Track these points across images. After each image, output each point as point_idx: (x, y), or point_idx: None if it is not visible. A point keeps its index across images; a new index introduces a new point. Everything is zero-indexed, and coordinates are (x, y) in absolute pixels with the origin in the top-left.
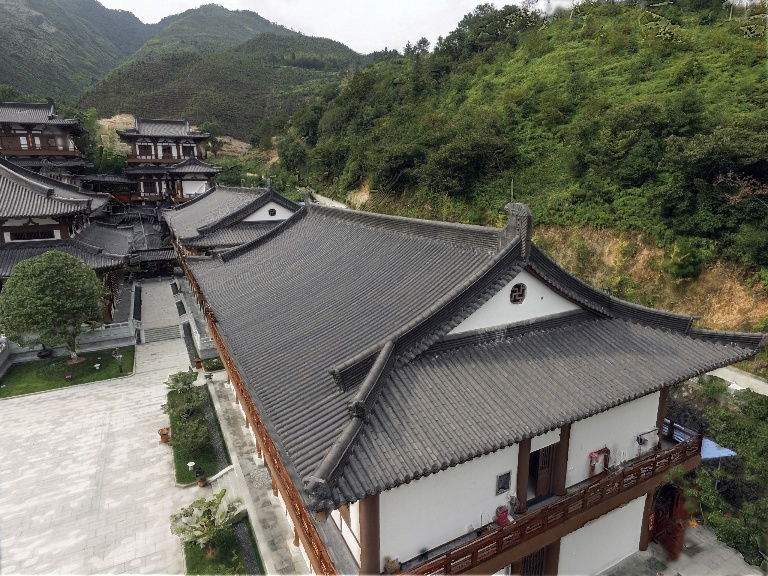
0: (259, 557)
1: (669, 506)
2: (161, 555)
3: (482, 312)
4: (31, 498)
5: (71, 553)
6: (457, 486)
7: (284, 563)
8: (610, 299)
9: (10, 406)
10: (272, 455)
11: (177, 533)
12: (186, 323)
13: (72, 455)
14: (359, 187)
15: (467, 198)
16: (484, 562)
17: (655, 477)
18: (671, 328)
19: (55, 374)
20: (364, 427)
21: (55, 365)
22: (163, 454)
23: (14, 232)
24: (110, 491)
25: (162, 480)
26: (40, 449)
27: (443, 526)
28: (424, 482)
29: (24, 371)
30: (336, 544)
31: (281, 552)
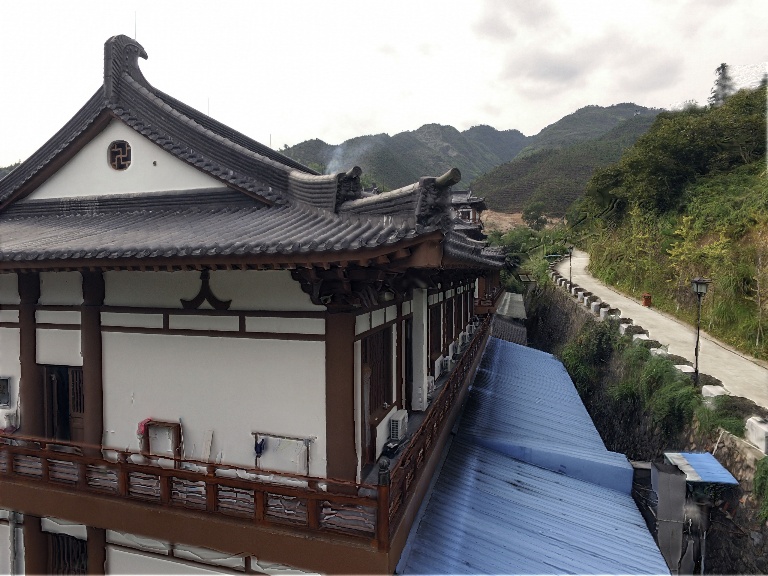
0: None
1: None
2: None
3: (72, 176)
4: None
5: None
6: None
7: None
8: (289, 174)
9: None
10: None
11: None
12: None
13: None
14: (590, 227)
15: (679, 211)
16: None
17: (211, 520)
18: (325, 206)
19: None
20: None
21: None
22: None
23: None
24: None
25: None
26: None
27: None
28: None
29: None
30: None
31: None
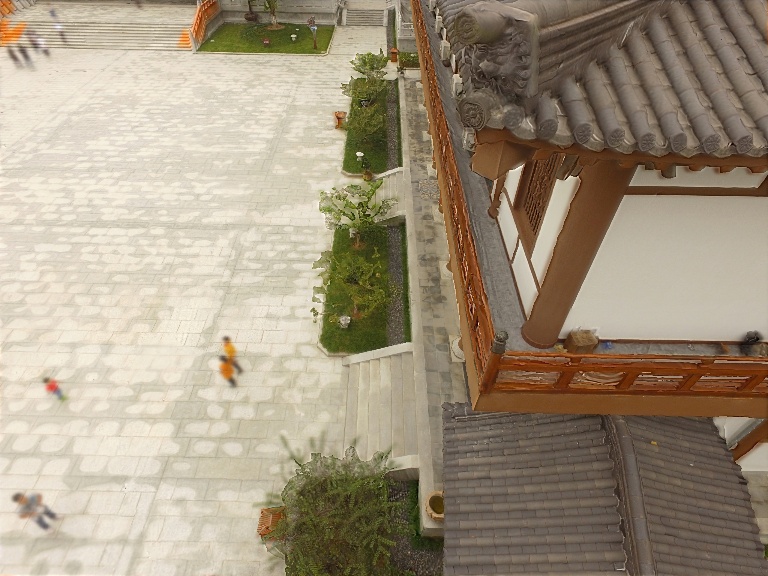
0: (406, 267)
1: None
2: (312, 231)
3: None
4: (216, 145)
5: (238, 201)
6: None
7: (430, 282)
8: None
9: (215, 60)
10: (441, 140)
11: (324, 211)
12: (392, 9)
13: (256, 117)
14: None
15: None
16: (762, 397)
17: None
18: None
19: (256, 37)
20: (672, 1)
21: (257, 28)
22: (337, 139)
23: None
24: (281, 159)
25: (330, 163)
26: (231, 104)
27: (704, 314)
28: (721, 221)
29: (231, 30)
30: (499, 275)
31: (430, 270)
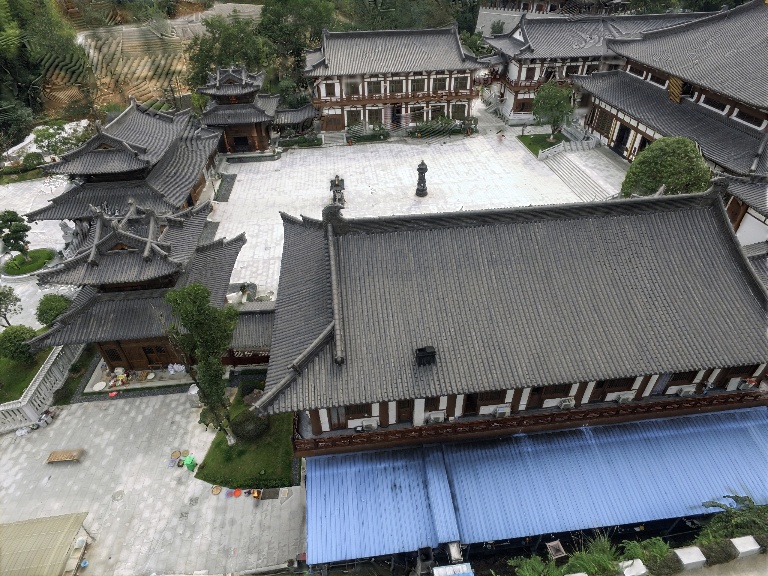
0: None
1: None
2: None
3: None
4: None
5: None
6: None
7: None
8: None
9: None
10: None
11: None
12: None
13: None
14: None
15: None
16: None
17: None
18: None
19: None
20: None
21: None
22: None
23: (741, 110)
24: None
25: None
26: None
27: None
28: None
29: None
30: None
31: None
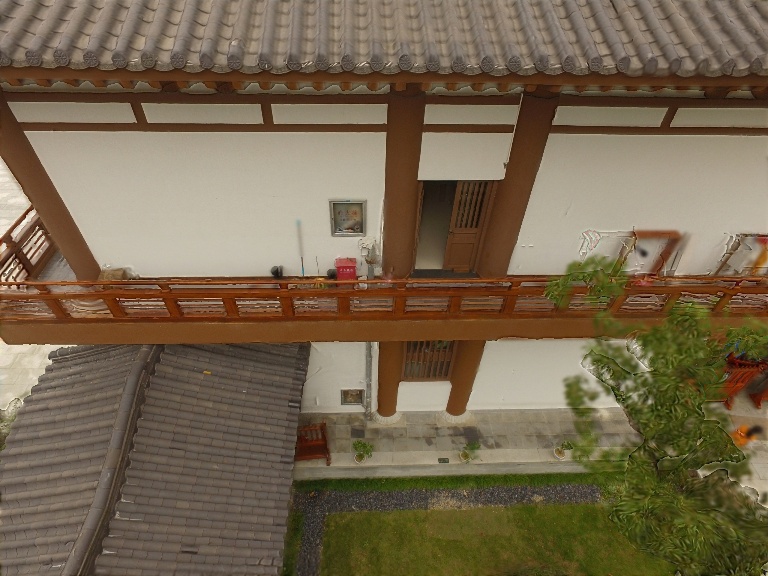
0: None
1: (759, 374)
2: None
3: None
4: None
5: None
6: (230, 190)
7: None
8: None
9: None
10: None
11: None
12: None
13: None
14: None
15: None
16: (254, 321)
17: (716, 318)
18: None
19: None
20: None
21: None
22: None
23: None
24: None
25: None
26: None
27: (216, 250)
28: (139, 157)
29: None
30: None
31: None
